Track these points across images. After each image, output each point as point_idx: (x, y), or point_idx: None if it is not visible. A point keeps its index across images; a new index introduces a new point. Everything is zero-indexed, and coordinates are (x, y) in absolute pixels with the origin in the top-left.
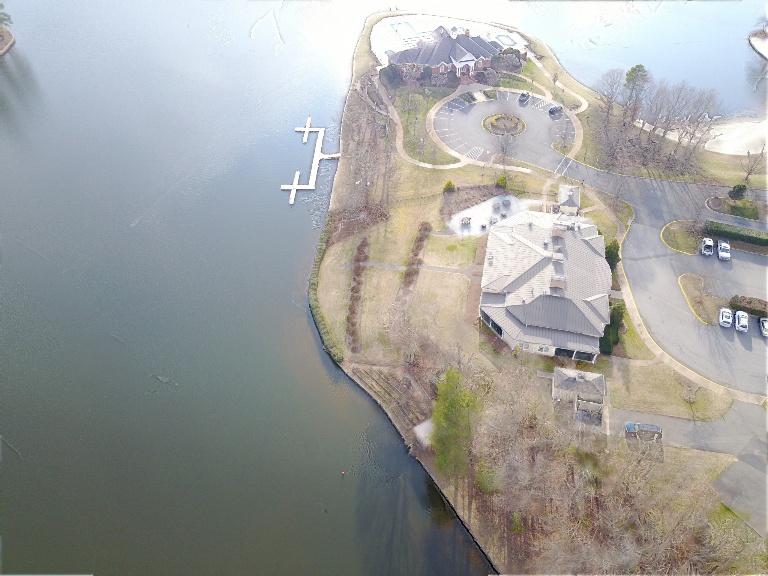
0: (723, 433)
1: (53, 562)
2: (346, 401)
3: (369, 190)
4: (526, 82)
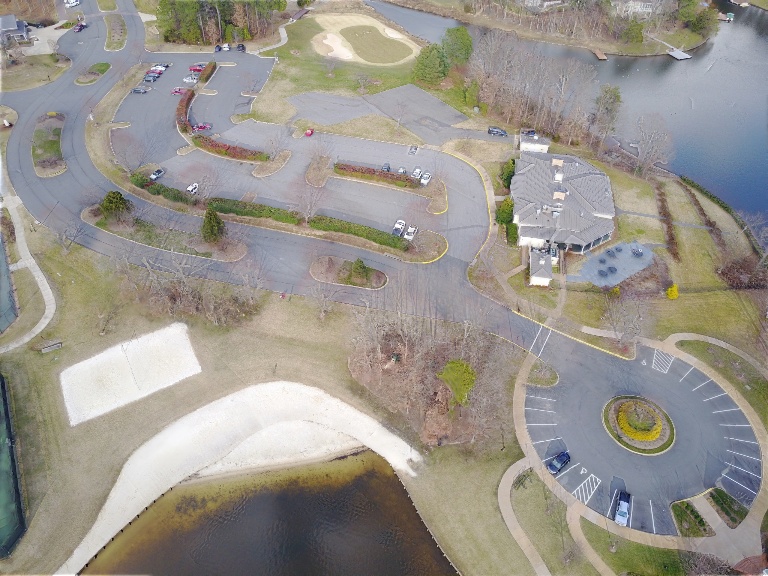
0: (454, 134)
1: (759, 132)
2: (665, 166)
3: (762, 311)
4: (628, 573)
